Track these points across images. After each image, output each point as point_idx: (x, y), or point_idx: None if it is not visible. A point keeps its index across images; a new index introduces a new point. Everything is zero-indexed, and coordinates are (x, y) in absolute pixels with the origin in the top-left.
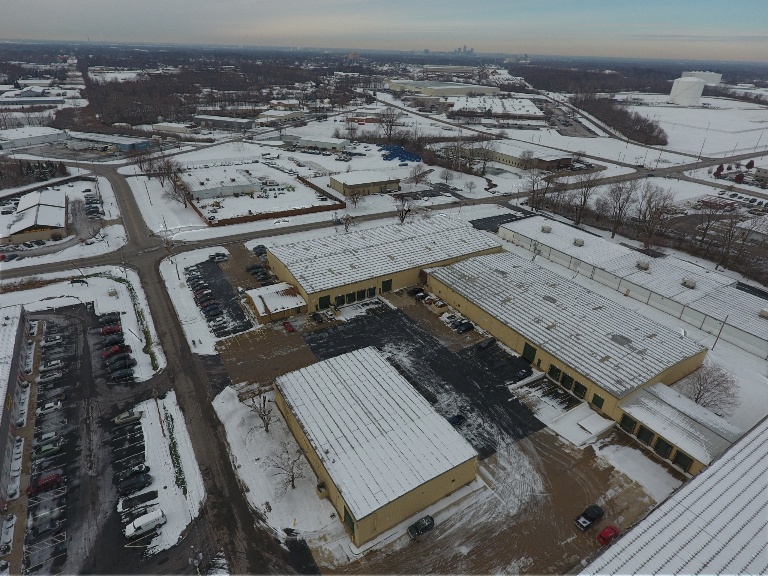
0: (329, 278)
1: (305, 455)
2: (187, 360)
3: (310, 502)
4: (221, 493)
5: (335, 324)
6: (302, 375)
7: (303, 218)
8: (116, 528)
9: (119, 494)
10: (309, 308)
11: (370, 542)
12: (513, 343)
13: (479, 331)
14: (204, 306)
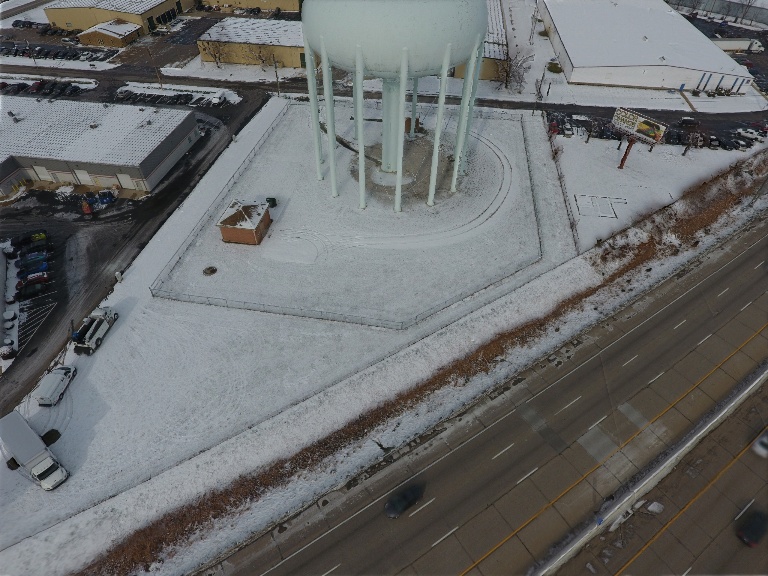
0: (139, 5)
1: (253, 64)
2: (105, 73)
3: (279, 70)
4: (234, 86)
5: (175, 33)
6: (211, 34)
7: (11, 2)
8: (205, 108)
9: (183, 104)
10: (145, 29)
11: (319, 66)
12: (290, 6)
13: (265, 11)
14: (54, 55)
